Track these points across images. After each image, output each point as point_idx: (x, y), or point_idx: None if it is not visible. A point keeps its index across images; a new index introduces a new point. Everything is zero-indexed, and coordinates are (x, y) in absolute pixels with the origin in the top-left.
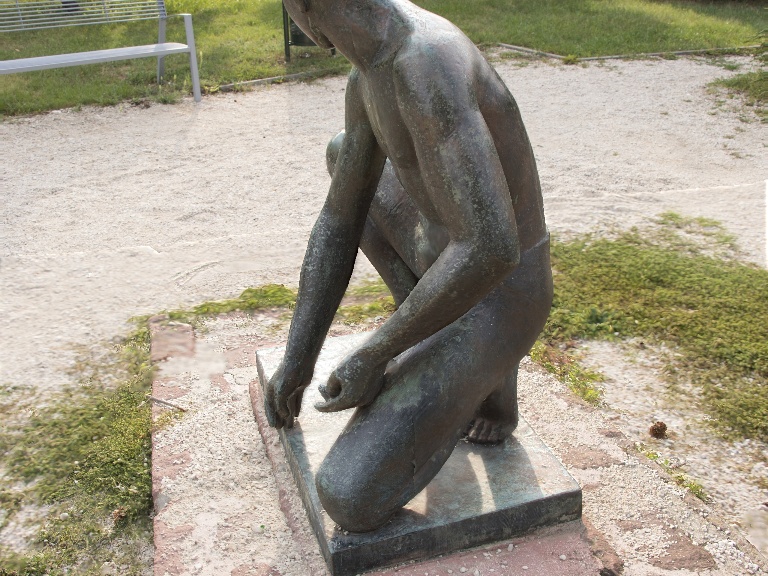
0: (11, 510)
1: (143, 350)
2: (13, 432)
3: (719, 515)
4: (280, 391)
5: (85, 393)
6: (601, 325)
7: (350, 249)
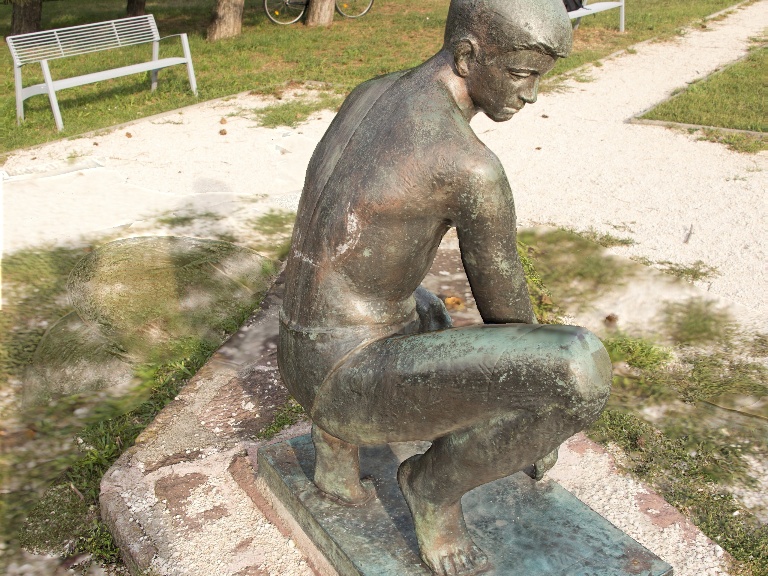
0: None
1: None
2: None
3: None
4: None
5: None
6: None
7: None
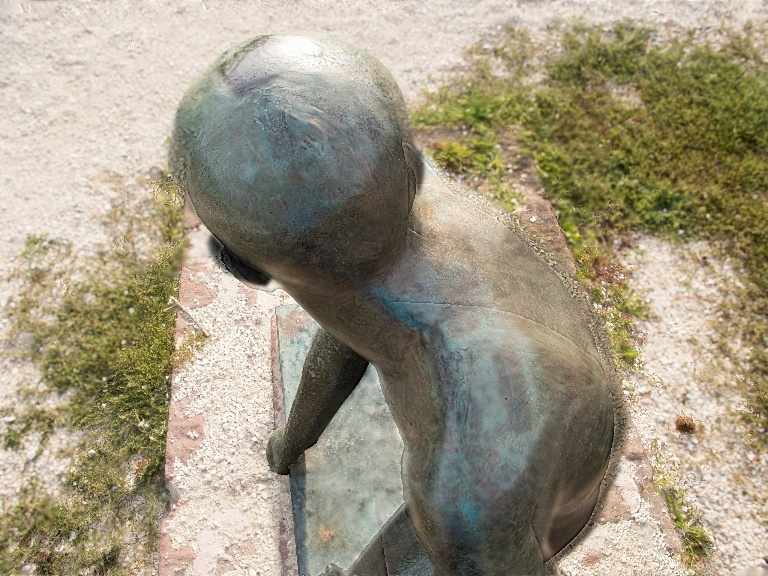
0: (45, 434)
1: (178, 202)
2: (48, 317)
3: (715, 569)
4: (279, 466)
5: (119, 261)
6: (668, 216)
7: (363, 361)
